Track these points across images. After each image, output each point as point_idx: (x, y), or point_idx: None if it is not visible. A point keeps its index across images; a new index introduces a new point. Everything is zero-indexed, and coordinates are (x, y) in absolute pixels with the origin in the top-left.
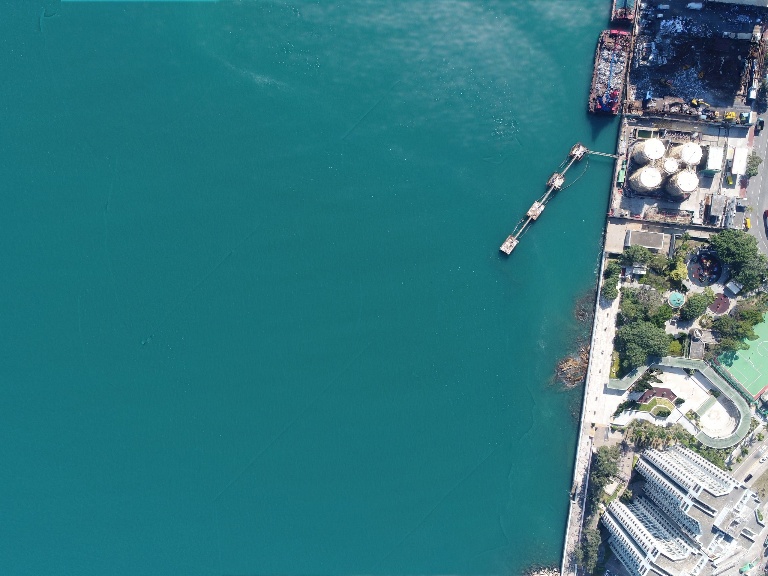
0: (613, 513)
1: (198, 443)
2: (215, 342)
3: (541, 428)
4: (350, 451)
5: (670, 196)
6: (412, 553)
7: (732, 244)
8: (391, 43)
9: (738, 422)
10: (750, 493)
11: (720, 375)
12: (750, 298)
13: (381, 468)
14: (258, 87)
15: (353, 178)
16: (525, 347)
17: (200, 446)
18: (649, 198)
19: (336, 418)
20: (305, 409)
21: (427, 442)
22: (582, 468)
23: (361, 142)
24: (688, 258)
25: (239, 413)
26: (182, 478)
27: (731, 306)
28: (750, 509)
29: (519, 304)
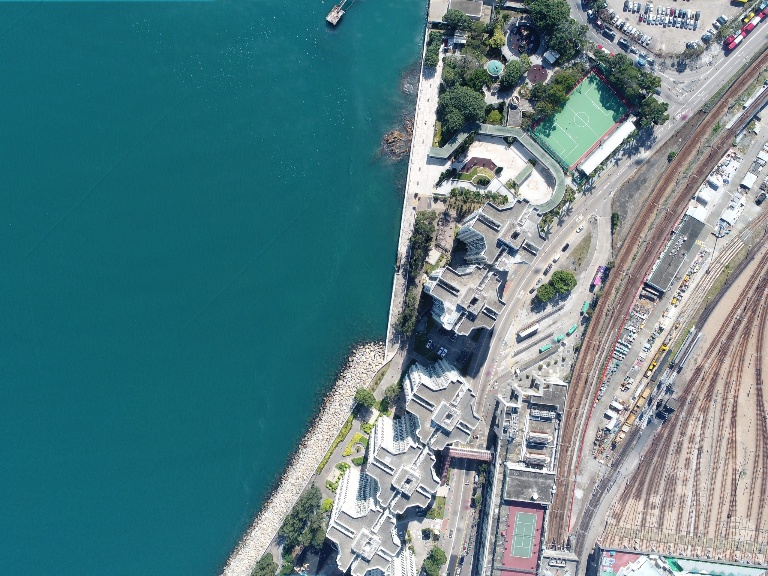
0: None
1: (10, 198)
2: (27, 92)
3: (368, 202)
4: (166, 207)
5: None
6: (227, 309)
7: (544, 7)
8: None
9: (554, 189)
10: None
11: None
12: (566, 69)
13: (196, 223)
14: None
15: None
16: (352, 120)
17: (12, 201)
18: None
19: (151, 172)
20: (119, 161)
21: (243, 197)
22: (406, 239)
23: None
24: (507, 27)
25: (51, 166)
26: None
27: (549, 77)
28: (533, 223)
29: (346, 77)
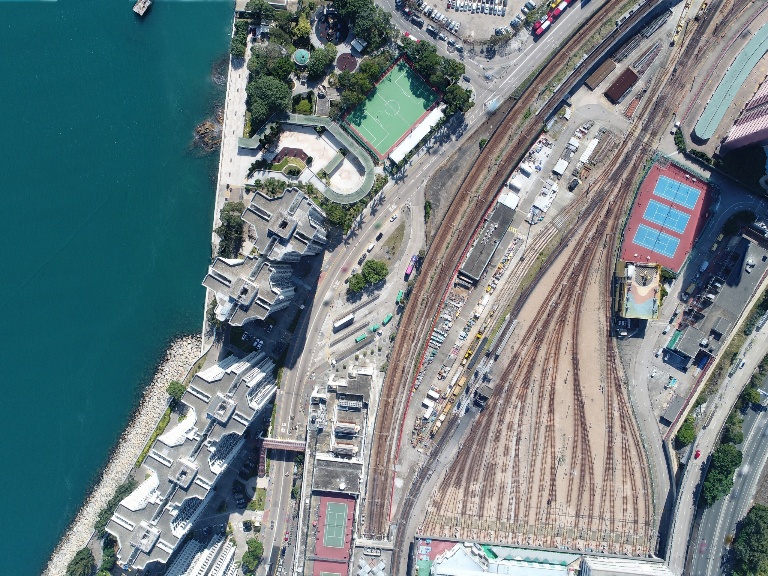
0: None
1: None
2: None
3: (182, 194)
4: None
5: None
6: (28, 304)
7: None
8: None
9: None
10: (303, 196)
11: (349, 134)
12: (375, 57)
13: None
14: None
15: None
16: (163, 111)
17: None
18: None
19: None
20: None
21: (41, 191)
22: None
23: None
24: (313, 16)
25: None
26: None
27: (358, 65)
28: (304, 212)
29: (157, 68)
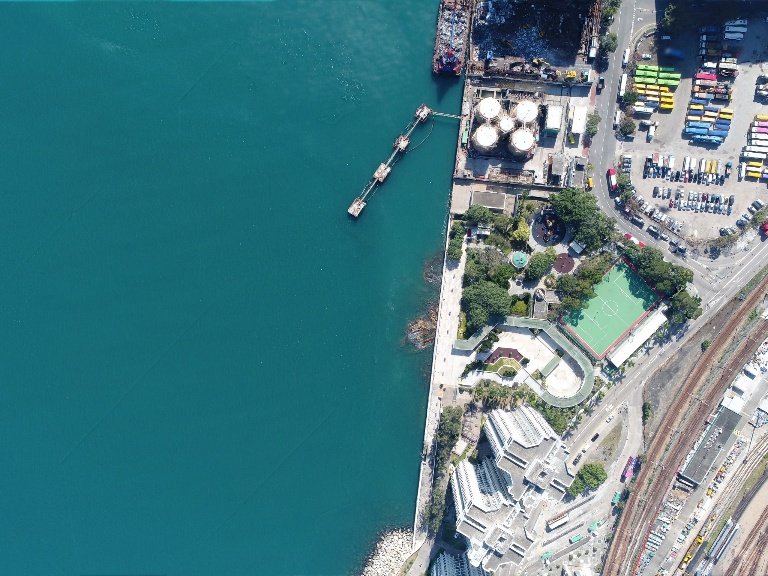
0: (457, 472)
1: (45, 405)
2: (59, 305)
3: (393, 390)
4: (194, 412)
5: (513, 156)
6: (256, 512)
7: (569, 202)
8: (225, 4)
9: (583, 381)
10: (560, 444)
11: (566, 335)
12: (594, 257)
13: (224, 428)
14: (111, 53)
15: (190, 140)
16: (375, 309)
17: (47, 408)
18: (493, 159)
19: (179, 379)
20: (148, 370)
21: (269, 402)
22: (432, 429)
23: (197, 104)
24: (531, 218)
25: (84, 375)
26: (32, 440)
27: (575, 266)
28: (560, 460)
29: (369, 266)
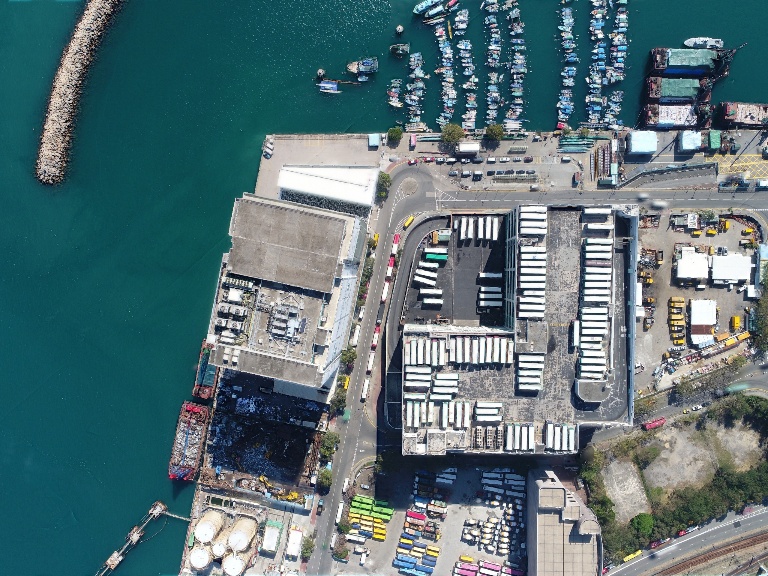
0: None
1: None
2: None
3: None
4: None
5: None
6: None
7: None
8: None
9: None
10: None
11: None
12: None
13: None
14: None
15: None
16: None
17: None
18: (217, 562)
19: None
20: None
21: None
22: None
23: None
24: None
25: None
26: None
27: None
28: None
29: None
